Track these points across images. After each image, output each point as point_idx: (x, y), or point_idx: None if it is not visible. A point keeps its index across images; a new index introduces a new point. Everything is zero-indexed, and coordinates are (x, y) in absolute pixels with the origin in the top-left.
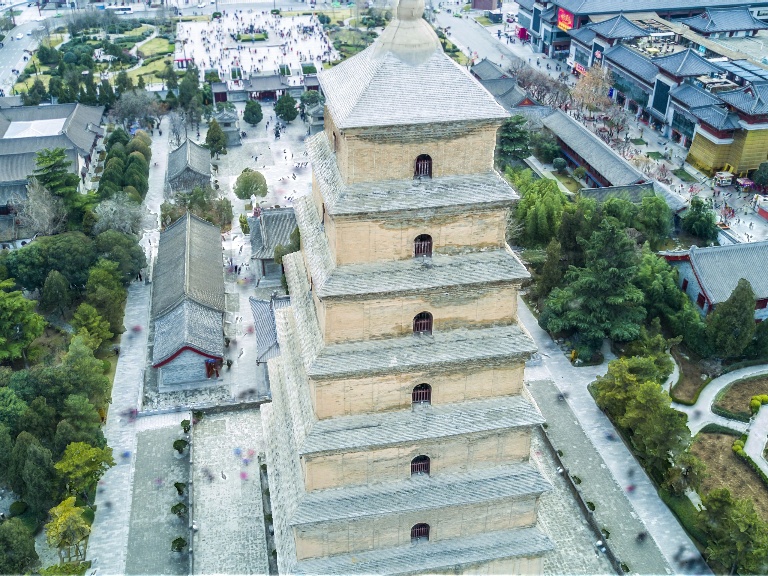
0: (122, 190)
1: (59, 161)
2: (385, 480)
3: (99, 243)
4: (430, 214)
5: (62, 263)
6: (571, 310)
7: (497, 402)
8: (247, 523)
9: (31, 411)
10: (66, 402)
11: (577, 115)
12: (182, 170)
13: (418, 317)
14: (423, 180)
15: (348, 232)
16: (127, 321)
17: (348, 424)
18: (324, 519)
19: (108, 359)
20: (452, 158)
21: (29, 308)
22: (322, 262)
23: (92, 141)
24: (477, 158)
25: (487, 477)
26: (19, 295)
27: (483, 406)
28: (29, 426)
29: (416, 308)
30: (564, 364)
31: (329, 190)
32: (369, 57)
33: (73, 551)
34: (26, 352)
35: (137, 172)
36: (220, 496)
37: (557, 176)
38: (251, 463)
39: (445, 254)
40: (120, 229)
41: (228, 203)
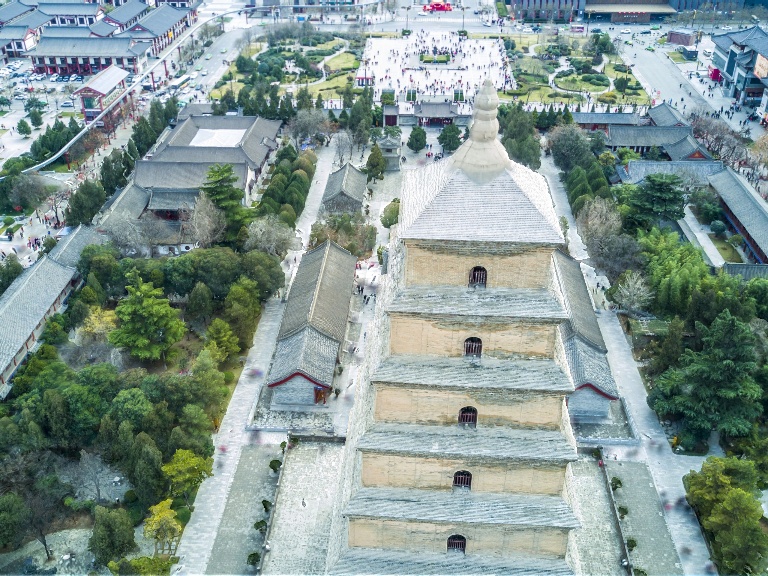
0: (280, 207)
1: (227, 177)
2: (422, 550)
3: (244, 261)
4: (480, 321)
5: (209, 276)
6: (680, 395)
7: (536, 499)
8: (314, 553)
9: (153, 414)
10: (184, 409)
11: (751, 174)
12: (337, 193)
13: (465, 409)
14: (477, 289)
15: (403, 327)
16: (258, 336)
17: (390, 495)
18: (360, 575)
19: (234, 370)
20: (506, 272)
21: (173, 315)
22: (381, 347)
23: (264, 155)
24: (531, 275)
25: (521, 566)
26: (166, 303)
27: (521, 500)
28: (149, 427)
29: (462, 402)
30: (664, 449)
31: (392, 286)
32: (443, 169)
33: (167, 545)
34: (166, 353)
35: (296, 191)
36: (296, 522)
37: (713, 239)
38: (331, 496)
39: (494, 357)
40: (265, 249)
41: (373, 230)
